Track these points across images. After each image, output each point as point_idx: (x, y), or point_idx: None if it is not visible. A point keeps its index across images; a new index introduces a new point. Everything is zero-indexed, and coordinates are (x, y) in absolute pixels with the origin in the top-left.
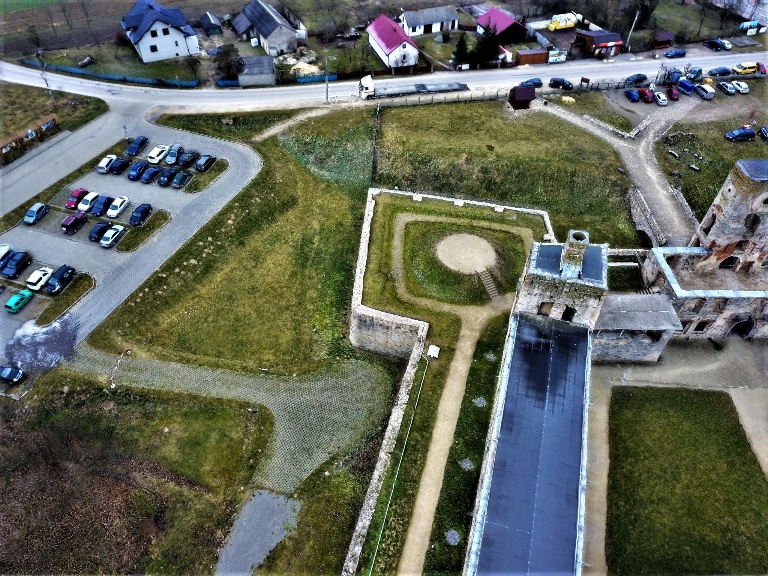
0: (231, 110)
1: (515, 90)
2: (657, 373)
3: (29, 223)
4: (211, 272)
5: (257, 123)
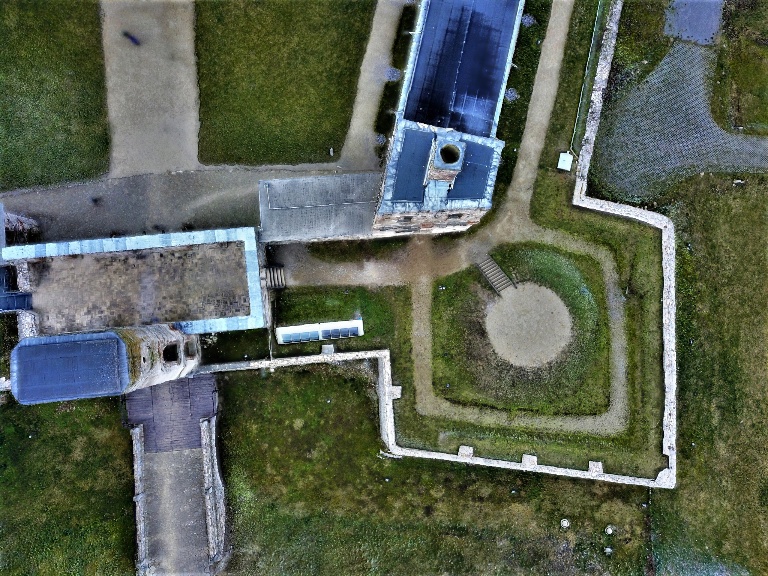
0: None
1: None
2: None
3: None
4: None
5: None
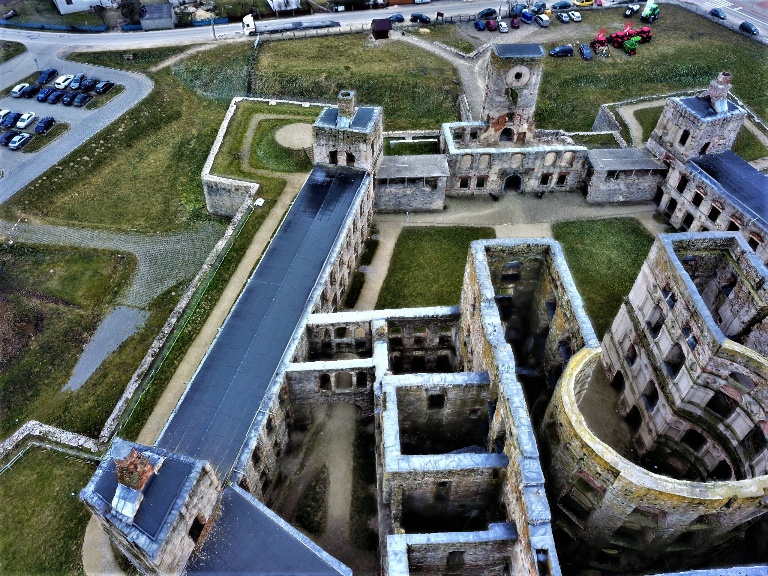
0: (132, 48)
1: (374, 22)
2: (441, 217)
3: None
4: (101, 166)
5: (154, 57)
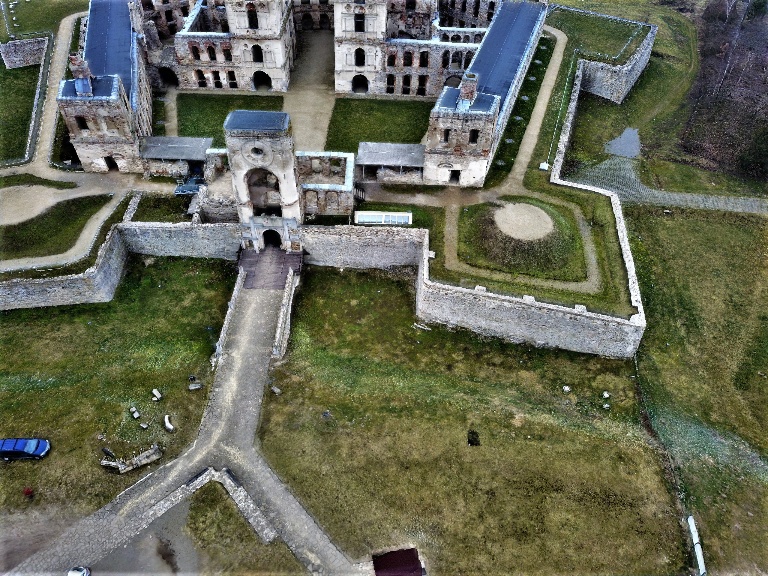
0: None
1: None
2: None
3: None
4: None
5: None
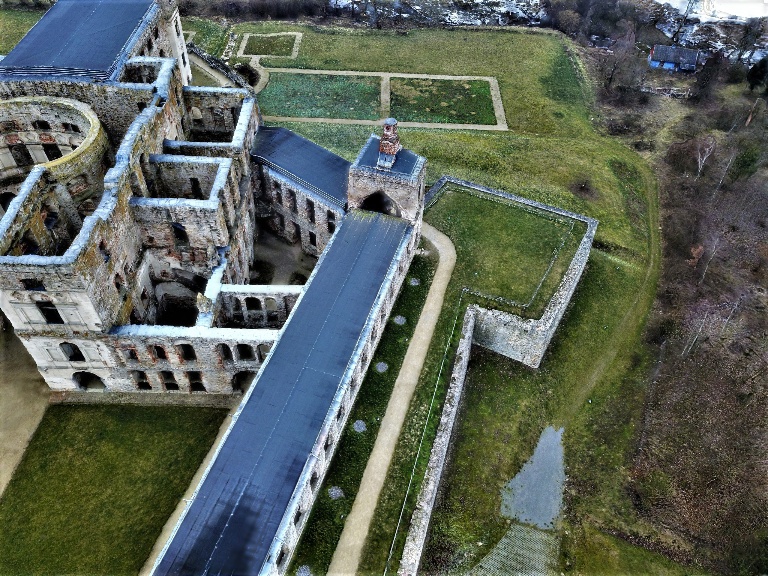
0: None
1: None
2: None
3: None
4: None
5: None
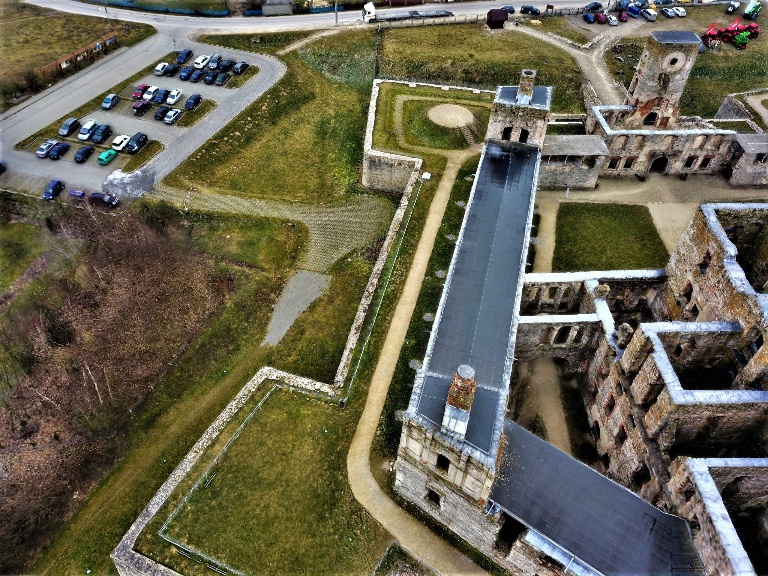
0: (258, 31)
1: (491, 12)
2: (594, 195)
3: (106, 108)
4: (252, 142)
5: (279, 41)
